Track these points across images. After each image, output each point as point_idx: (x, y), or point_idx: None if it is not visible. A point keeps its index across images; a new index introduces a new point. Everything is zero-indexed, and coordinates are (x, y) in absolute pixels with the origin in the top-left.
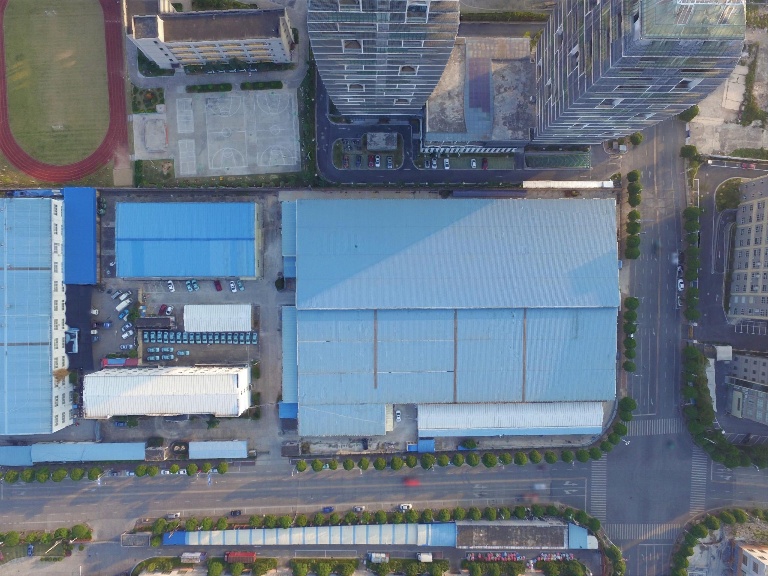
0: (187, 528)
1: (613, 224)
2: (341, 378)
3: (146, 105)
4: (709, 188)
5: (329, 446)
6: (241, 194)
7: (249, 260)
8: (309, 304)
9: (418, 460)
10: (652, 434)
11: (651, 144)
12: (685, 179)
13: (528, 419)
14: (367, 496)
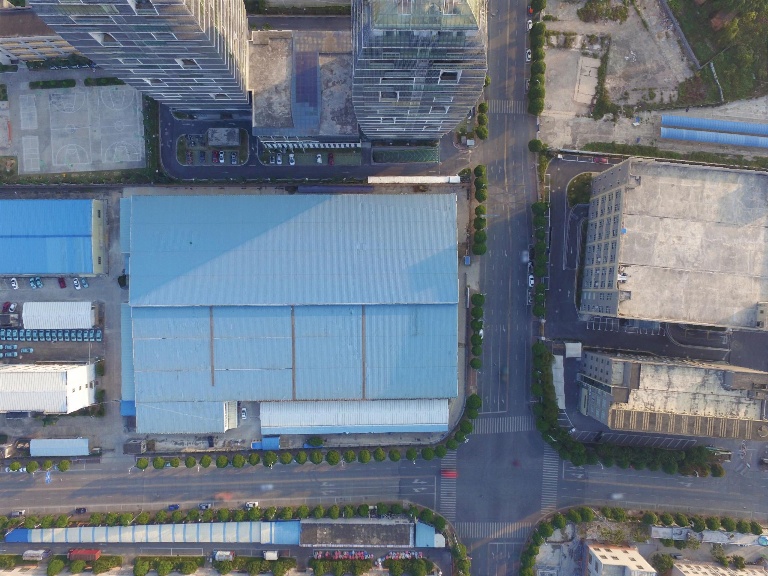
0: (24, 526)
1: (453, 220)
2: (178, 375)
3: None
4: (561, 183)
5: (175, 444)
6: (85, 191)
7: (86, 257)
8: (142, 301)
9: (261, 458)
10: (502, 432)
11: (501, 138)
12: (536, 174)
13: (372, 417)
14: (213, 494)
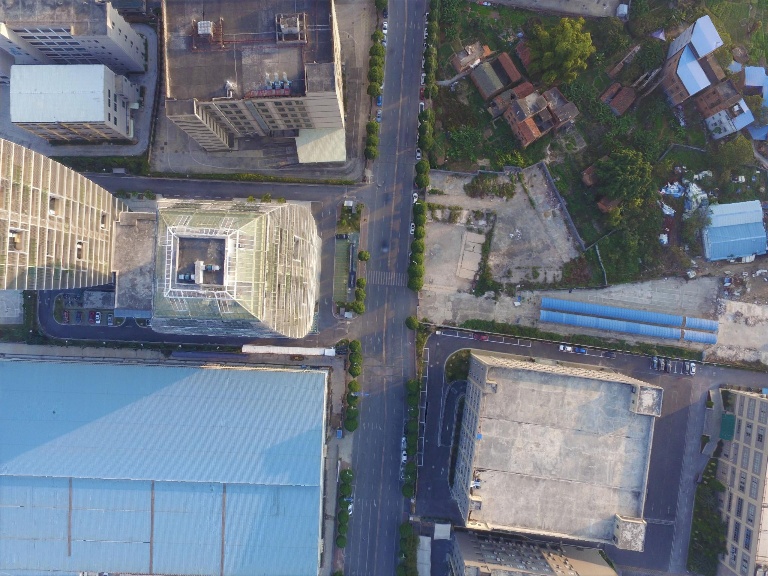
0: None
1: (321, 400)
2: (34, 544)
3: None
4: (439, 358)
5: None
6: None
7: None
8: (0, 470)
9: None
10: None
11: (381, 310)
12: (414, 348)
13: None
14: None
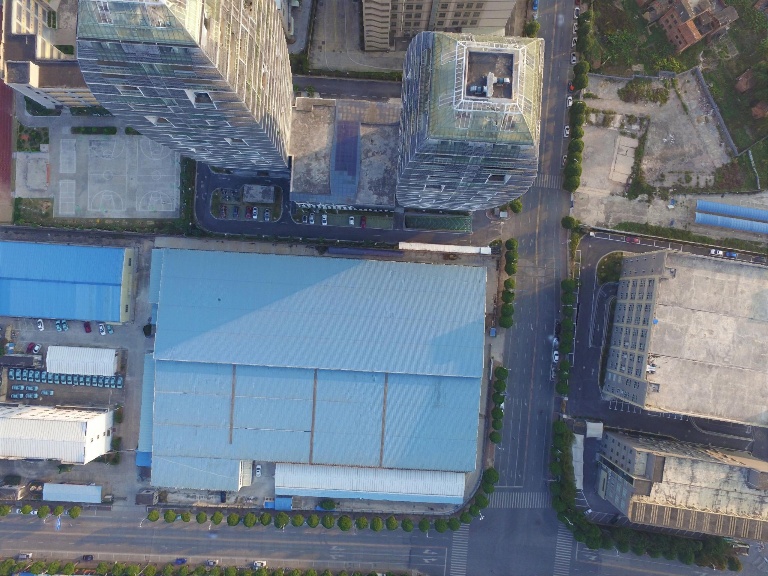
0: (32, 571)
1: (482, 293)
2: (196, 431)
3: (30, 144)
4: (591, 260)
5: (187, 496)
6: (118, 237)
7: (114, 305)
8: (167, 355)
9: (273, 518)
10: (517, 507)
11: (534, 212)
12: (567, 249)
13: (387, 484)
14: (222, 550)
